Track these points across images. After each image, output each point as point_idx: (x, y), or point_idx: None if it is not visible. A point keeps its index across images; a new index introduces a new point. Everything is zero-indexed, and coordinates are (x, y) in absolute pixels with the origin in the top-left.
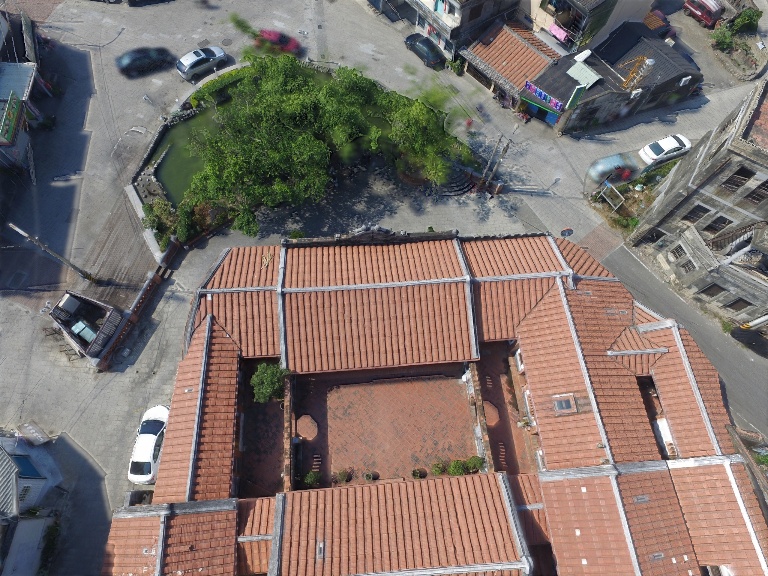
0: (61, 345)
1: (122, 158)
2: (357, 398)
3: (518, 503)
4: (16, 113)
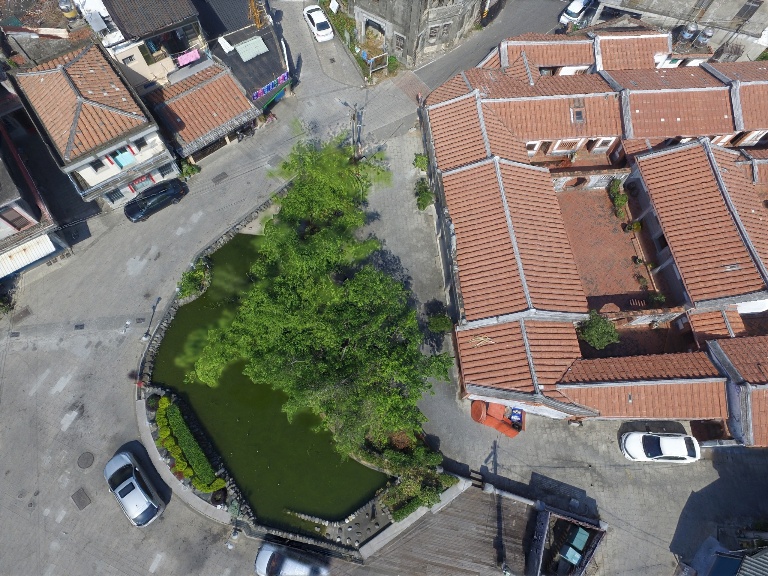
0: None
1: None
2: None
3: None
4: None
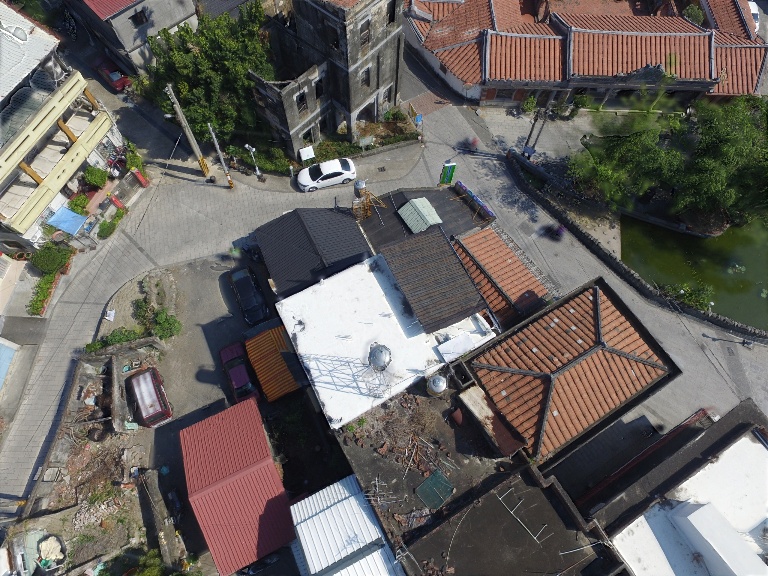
0: None
1: None
2: None
3: None
4: None
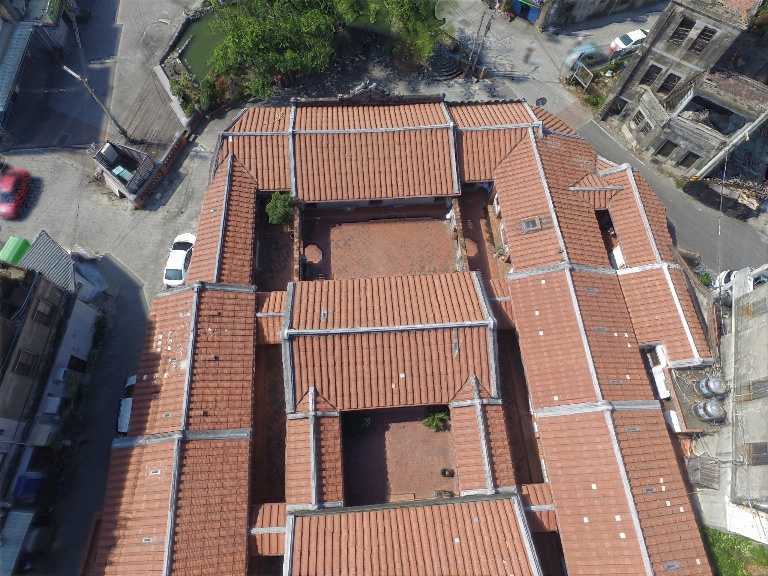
0: (103, 187)
1: (150, 46)
2: (356, 233)
3: (489, 296)
4: None
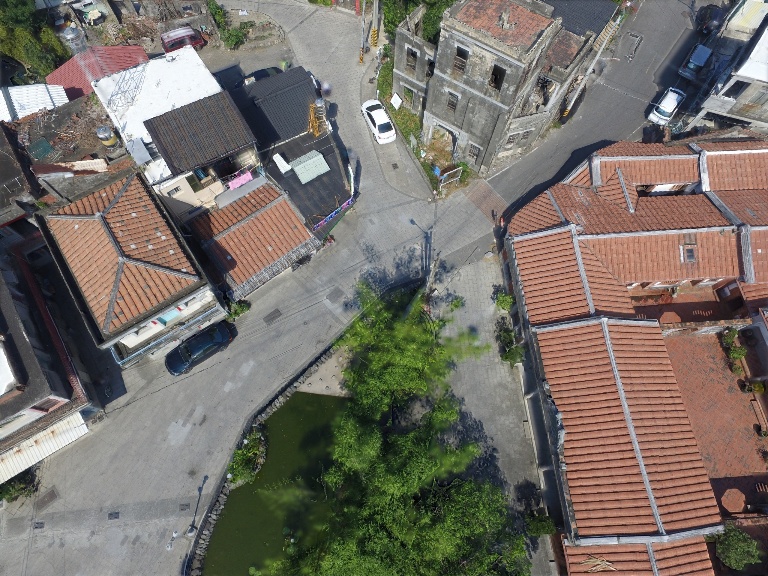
0: None
1: None
2: None
3: None
4: None
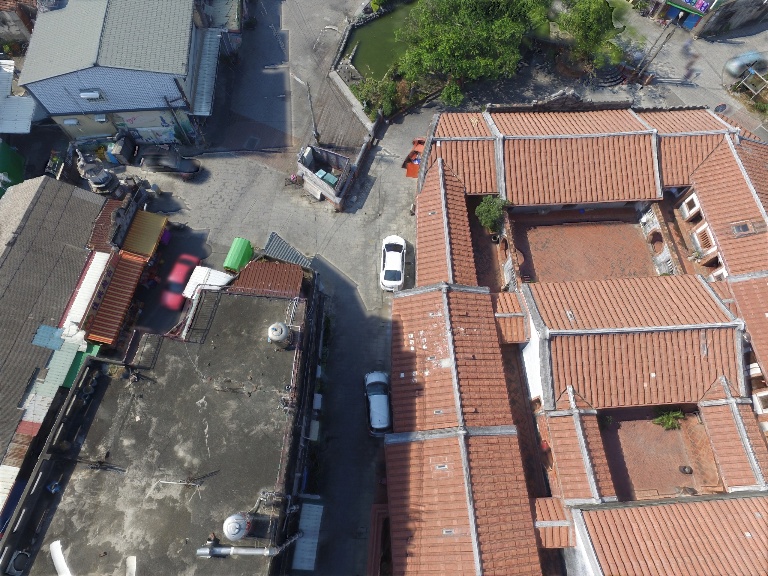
0: None
1: (318, 52)
2: (552, 236)
3: None
4: (240, 6)
